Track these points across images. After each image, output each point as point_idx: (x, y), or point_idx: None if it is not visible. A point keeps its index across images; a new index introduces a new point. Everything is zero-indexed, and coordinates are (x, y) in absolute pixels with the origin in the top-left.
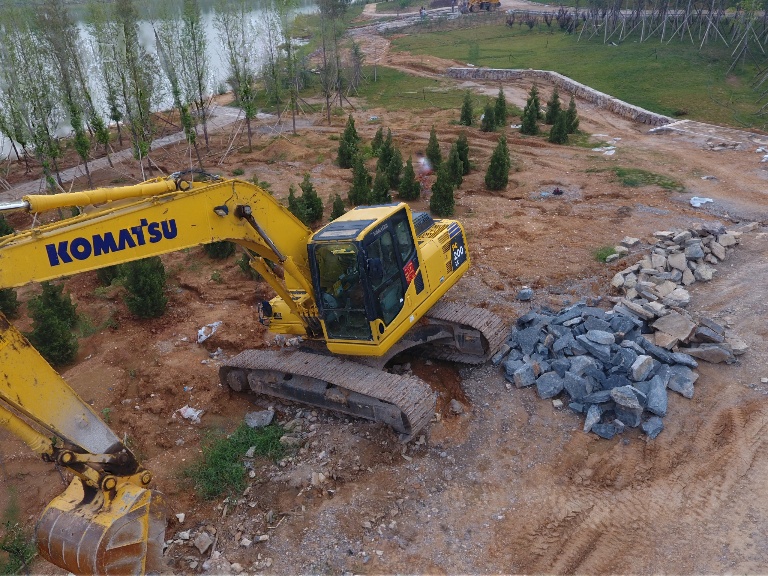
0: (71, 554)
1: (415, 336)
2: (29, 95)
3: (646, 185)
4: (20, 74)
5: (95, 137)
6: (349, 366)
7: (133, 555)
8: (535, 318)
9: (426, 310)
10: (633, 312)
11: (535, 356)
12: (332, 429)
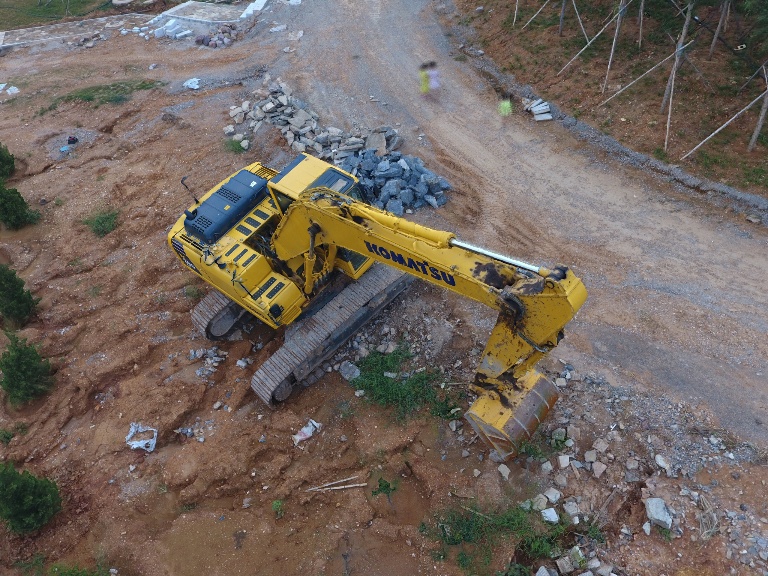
0: (543, 410)
1: None
2: None
3: (131, 94)
4: None
5: None
6: (367, 279)
7: None
8: None
9: None
10: (350, 151)
11: None
12: (401, 314)
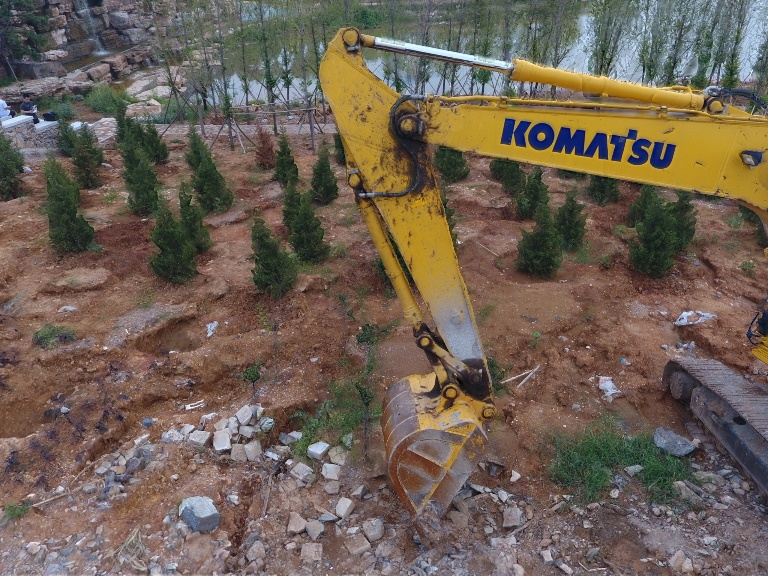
0: (389, 429)
1: None
2: (676, 23)
3: None
4: (685, 6)
5: (720, 82)
6: None
7: (429, 472)
8: None
9: None
10: None
11: None
12: (750, 521)
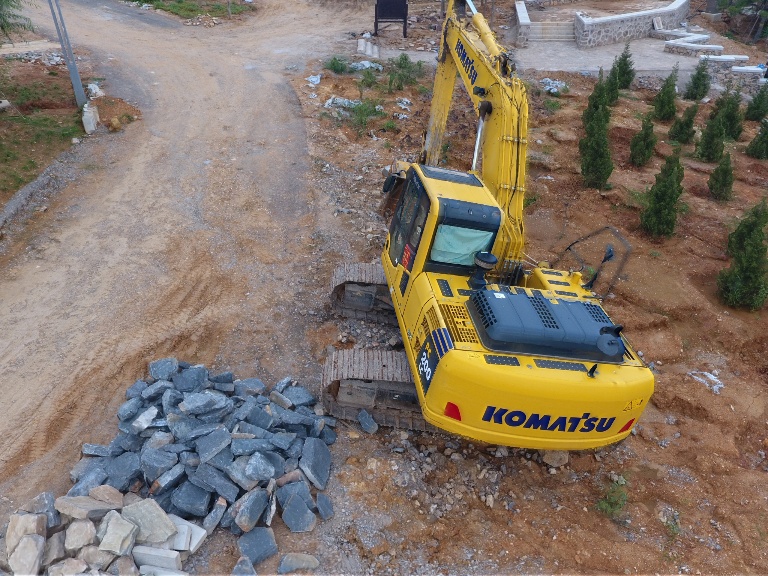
0: None
1: None
2: None
3: None
4: None
5: None
6: None
7: None
8: None
9: None
10: None
11: (280, 410)
12: None
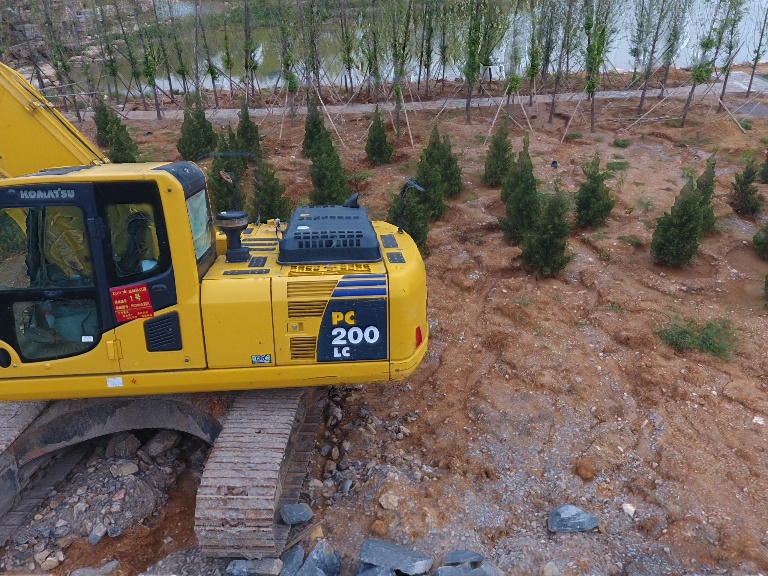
0: None
1: (204, 422)
2: (465, 8)
3: None
4: None
5: None
6: None
7: None
8: (373, 567)
9: (183, 389)
10: None
11: None
12: None
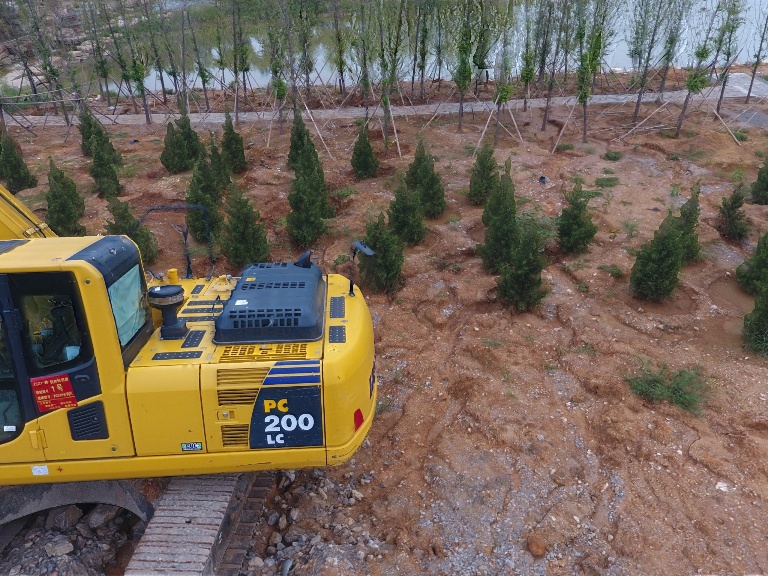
0: None
1: None
2: (458, 12)
3: None
4: None
5: None
6: None
7: None
8: None
9: (112, 475)
10: None
11: None
12: None
